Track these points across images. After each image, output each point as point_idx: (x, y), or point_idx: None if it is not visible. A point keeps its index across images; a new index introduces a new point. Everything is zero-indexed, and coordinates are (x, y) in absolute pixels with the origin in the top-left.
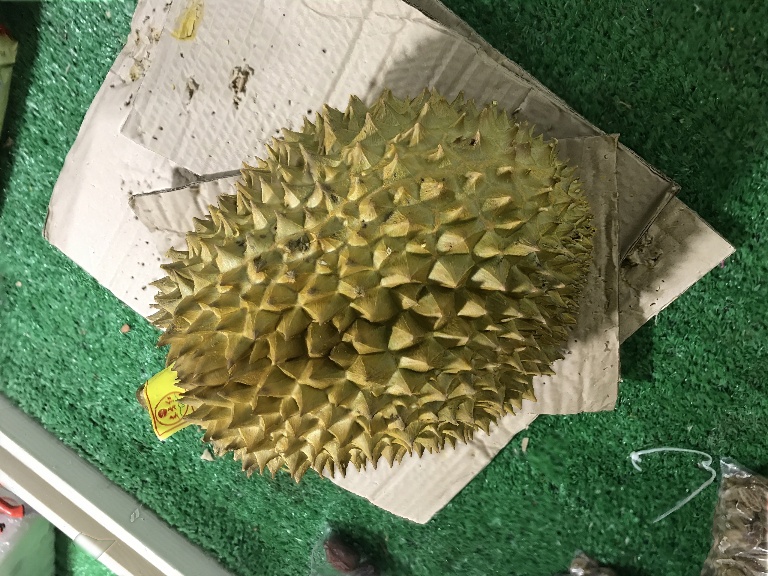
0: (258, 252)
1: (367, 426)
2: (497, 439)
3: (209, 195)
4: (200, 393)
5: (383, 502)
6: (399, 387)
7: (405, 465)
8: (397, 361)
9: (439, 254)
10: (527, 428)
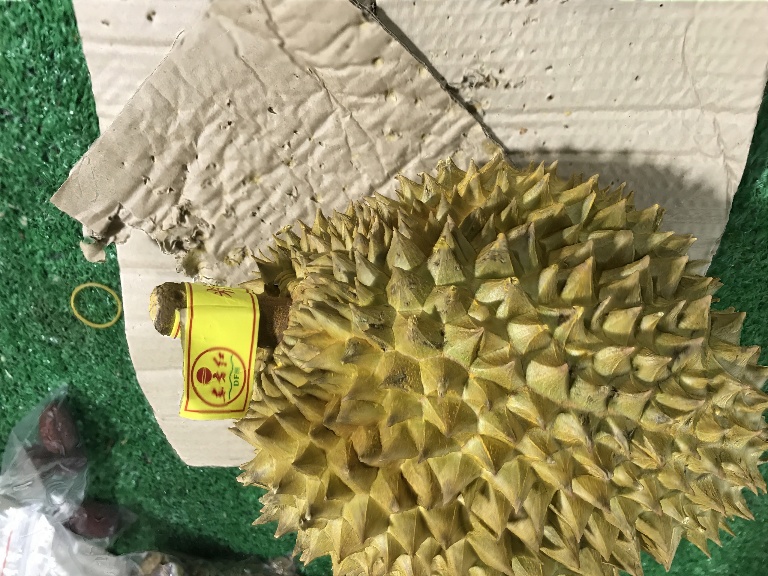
0: (588, 408)
1: None
2: None
3: (367, 41)
4: (352, 468)
5: (171, 428)
6: None
7: None
8: (555, 574)
9: (682, 525)
10: None
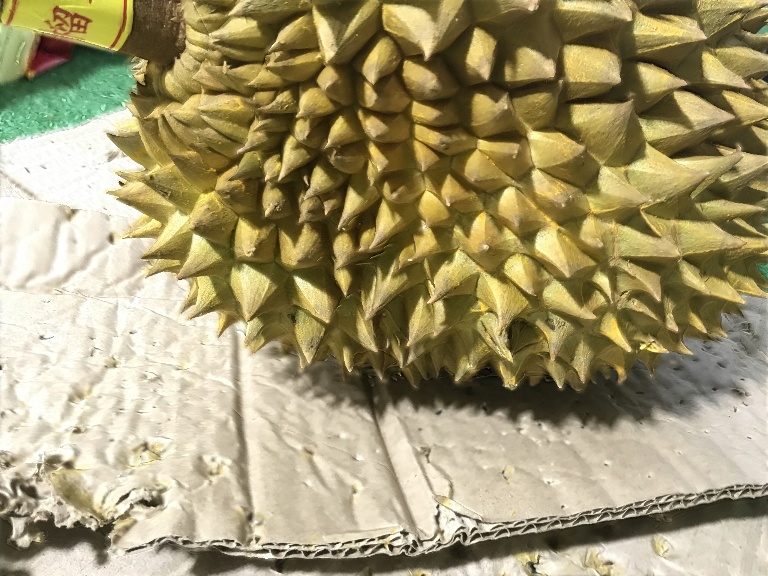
0: None
1: None
2: None
3: (87, 226)
4: None
5: None
6: None
7: None
8: None
9: None
10: None
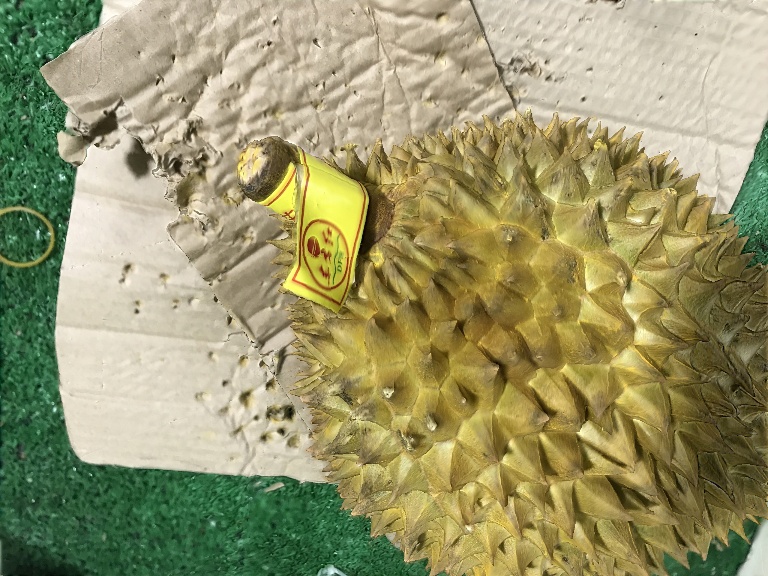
0: (722, 338)
1: (542, 571)
2: (269, 466)
3: None
4: None
5: (79, 407)
6: (605, 569)
7: (160, 403)
8: None
9: None
10: (302, 482)
